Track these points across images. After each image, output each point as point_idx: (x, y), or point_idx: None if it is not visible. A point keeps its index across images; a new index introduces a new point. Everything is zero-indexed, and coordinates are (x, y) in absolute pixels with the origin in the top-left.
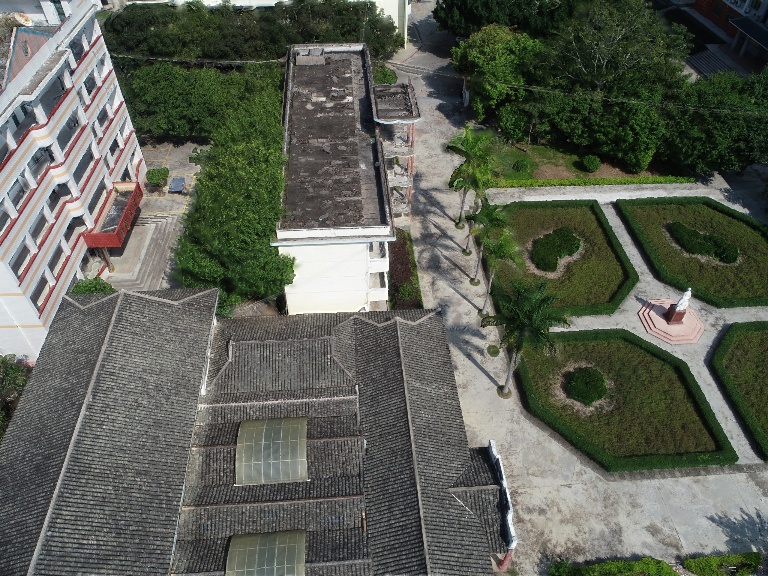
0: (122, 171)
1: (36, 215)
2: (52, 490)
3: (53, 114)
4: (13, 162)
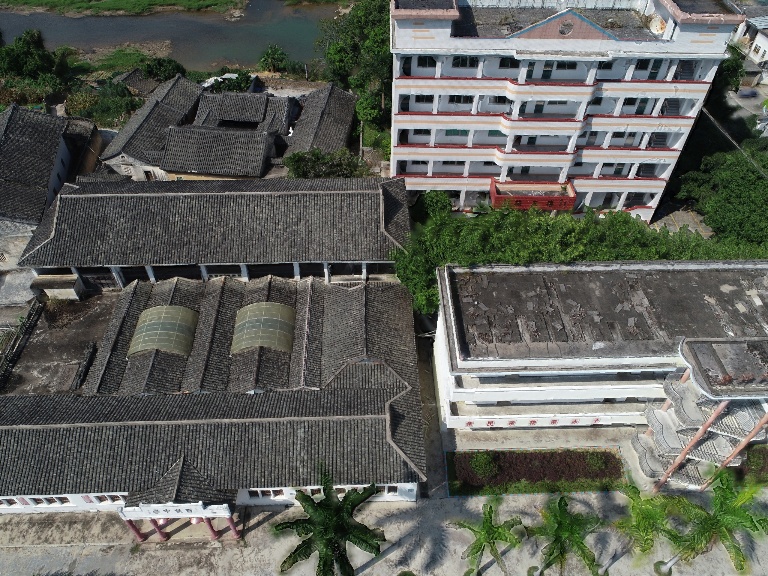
0: (605, 190)
1: (455, 128)
2: None
3: (538, 85)
4: (466, 84)
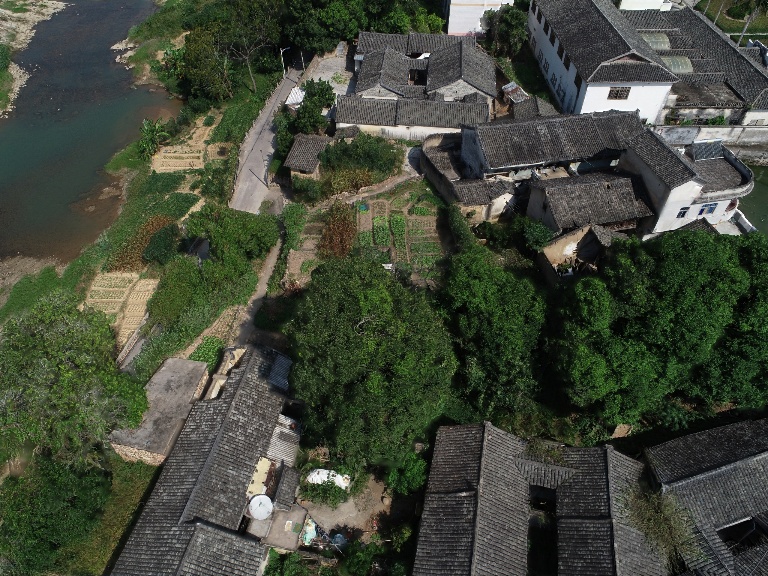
0: None
1: None
2: (598, 12)
3: None
4: None
